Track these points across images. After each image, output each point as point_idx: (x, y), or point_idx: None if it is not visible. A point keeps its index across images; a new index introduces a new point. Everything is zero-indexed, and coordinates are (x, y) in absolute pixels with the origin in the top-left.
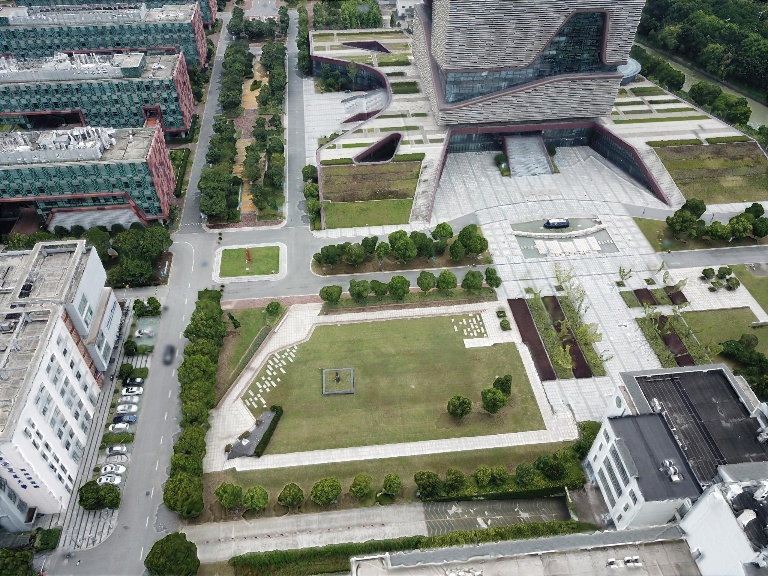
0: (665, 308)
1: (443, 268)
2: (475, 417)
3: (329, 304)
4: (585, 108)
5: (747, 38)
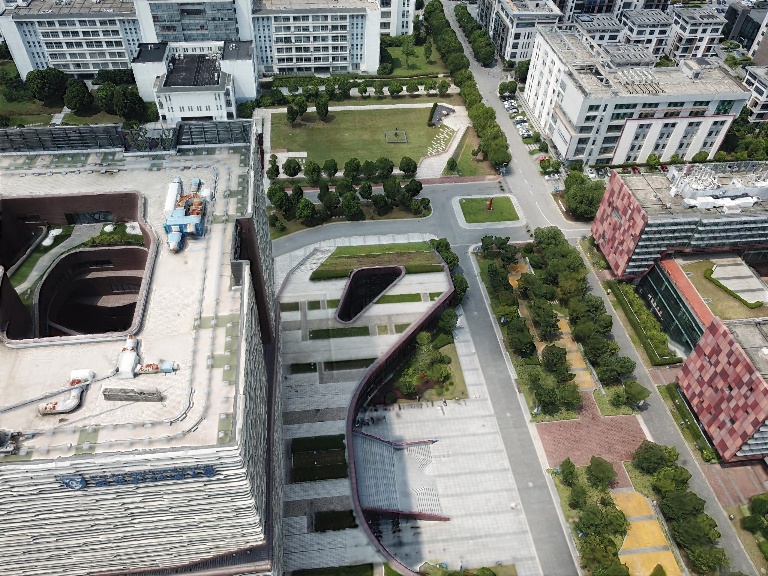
0: None
1: None
2: (311, 120)
3: (409, 176)
4: None
5: None
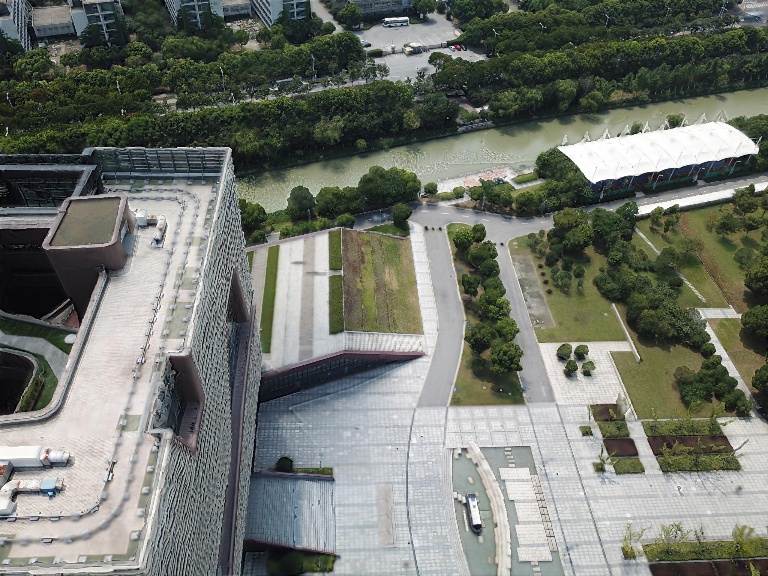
0: (633, 432)
1: None
2: None
3: None
4: None
5: (86, 137)
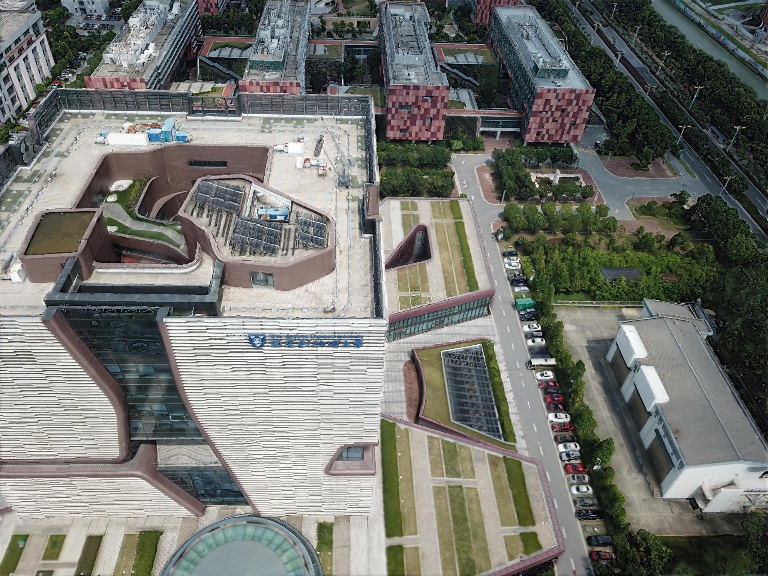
0: None
1: None
2: None
3: None
4: None
5: None
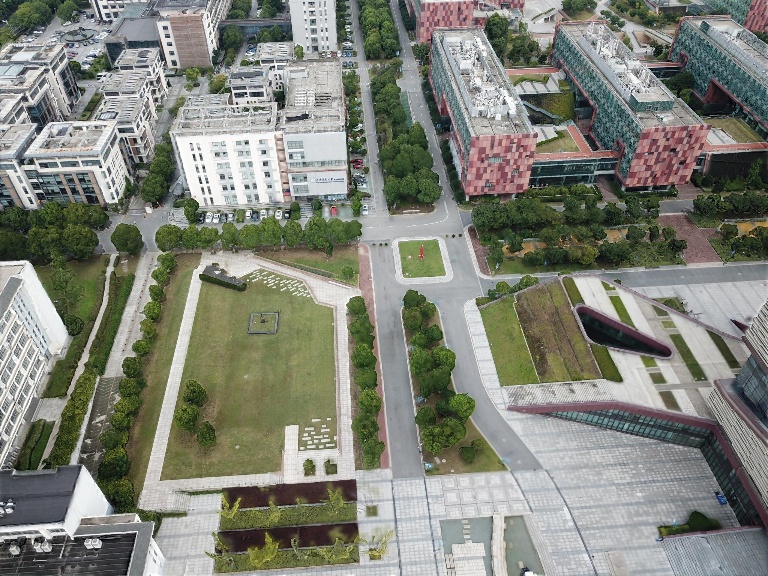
0: None
1: None
2: None
3: None
4: None
5: None
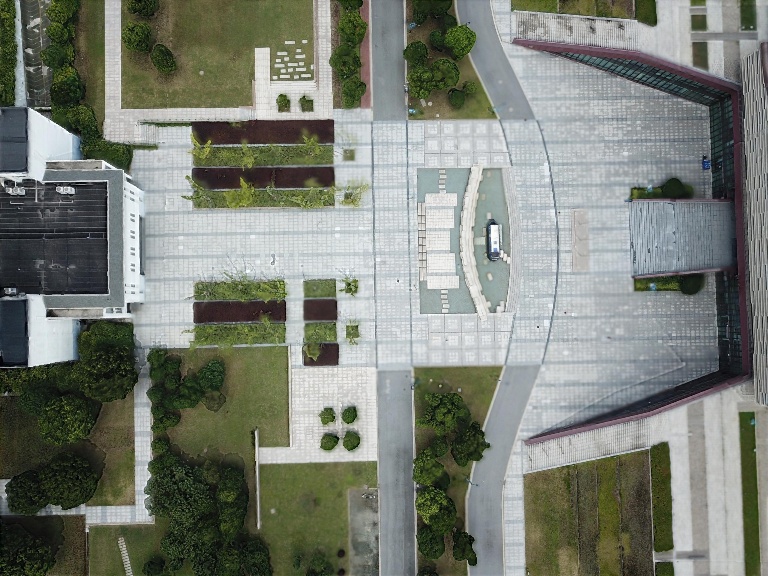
0: (299, 330)
1: (406, 45)
2: None
3: None
4: (767, 347)
5: None
